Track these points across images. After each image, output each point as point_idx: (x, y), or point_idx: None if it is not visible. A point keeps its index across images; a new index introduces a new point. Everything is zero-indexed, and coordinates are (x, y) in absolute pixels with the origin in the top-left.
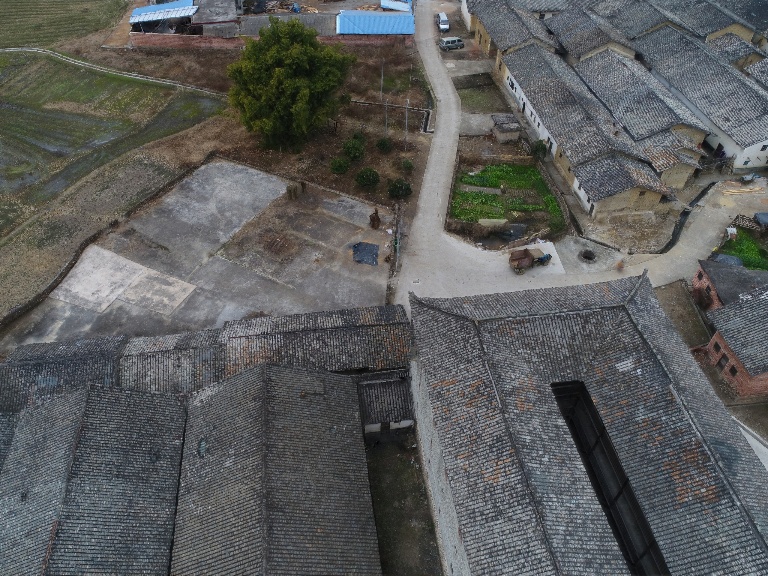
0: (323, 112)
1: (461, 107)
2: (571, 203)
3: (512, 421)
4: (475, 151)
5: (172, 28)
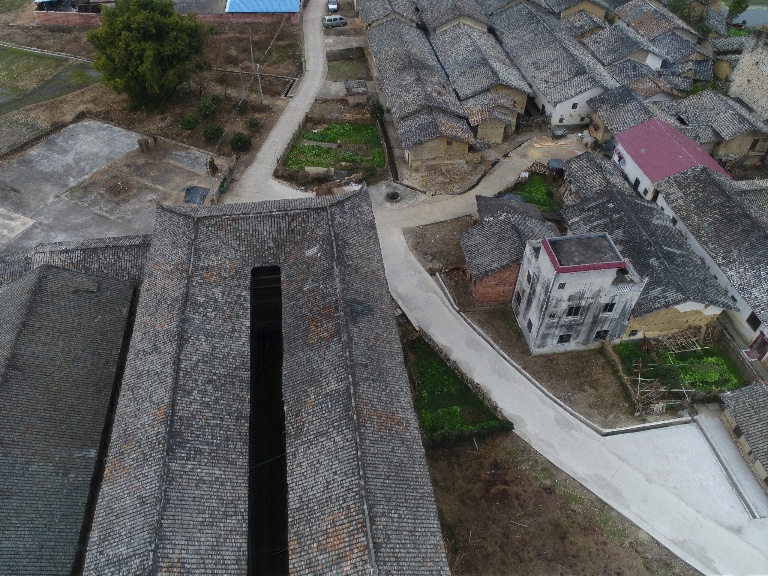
0: (171, 73)
1: (326, 76)
2: (397, 155)
3: (192, 287)
4: (325, 112)
5: (75, 7)
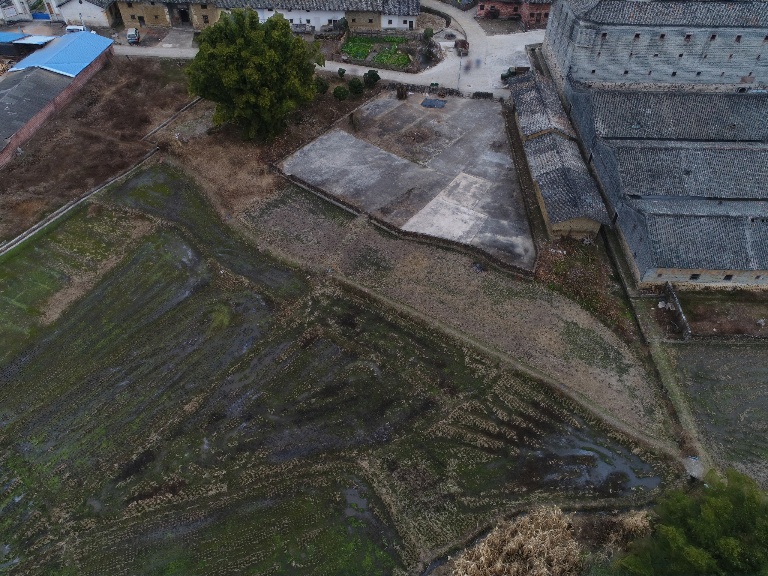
0: None
1: None
2: None
3: None
4: None
5: None
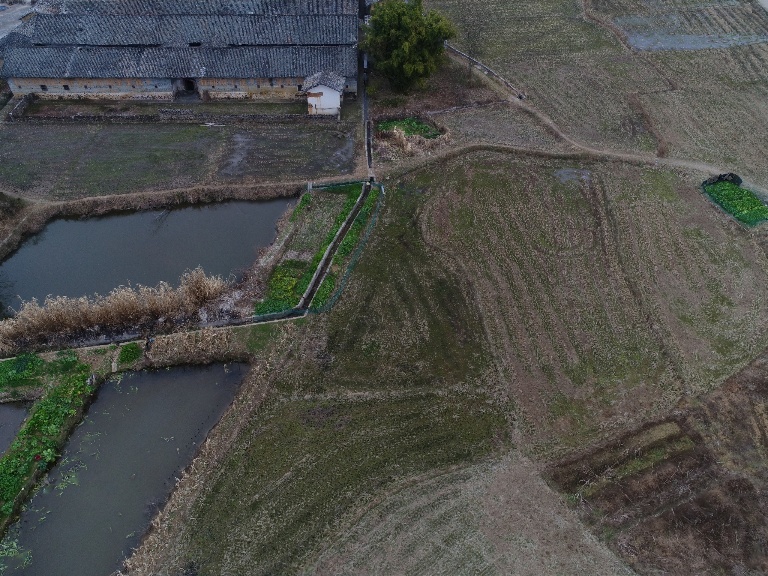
0: None
1: None
2: None
3: None
4: None
5: None
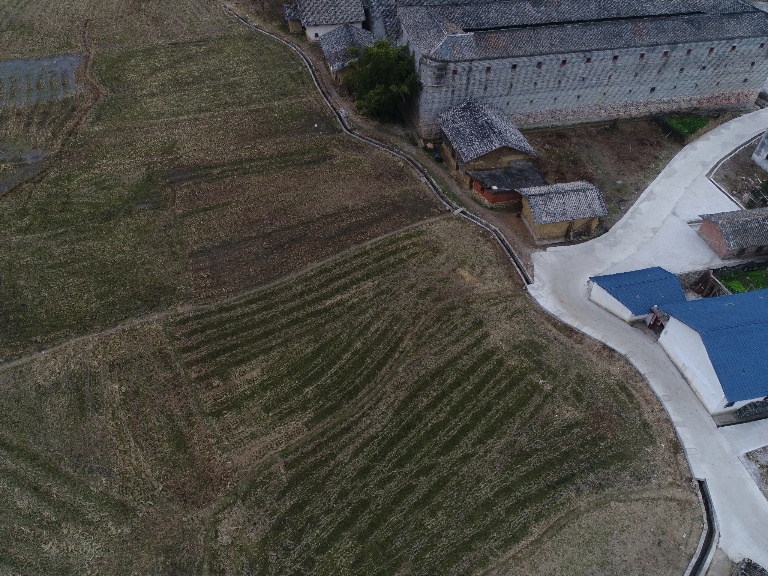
0: None
1: None
2: None
3: None
4: None
5: None
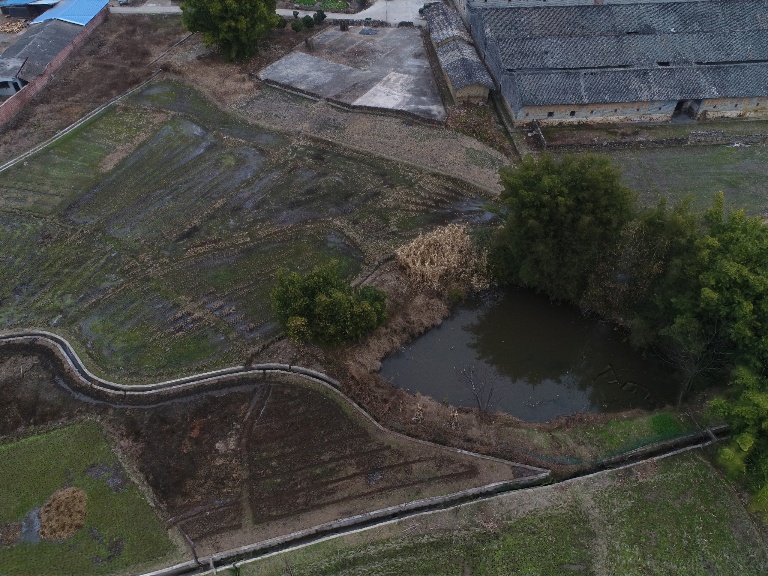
0: None
1: None
2: None
3: None
4: (276, 5)
5: None
